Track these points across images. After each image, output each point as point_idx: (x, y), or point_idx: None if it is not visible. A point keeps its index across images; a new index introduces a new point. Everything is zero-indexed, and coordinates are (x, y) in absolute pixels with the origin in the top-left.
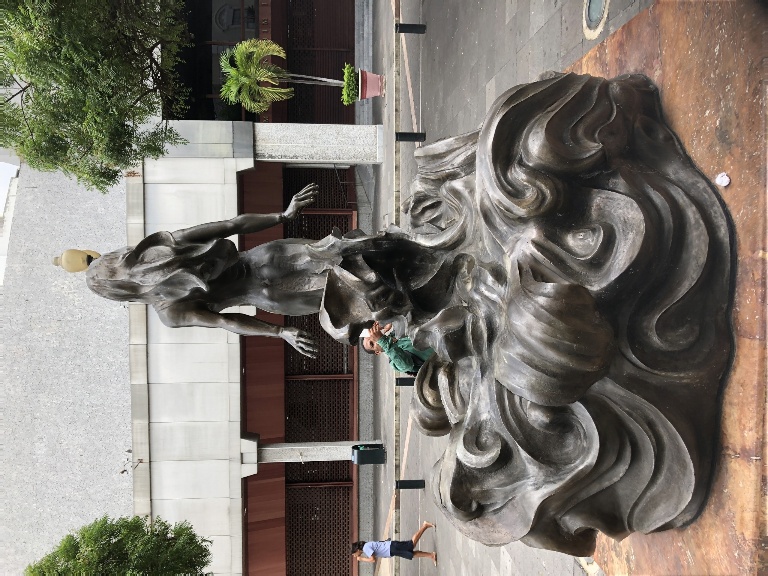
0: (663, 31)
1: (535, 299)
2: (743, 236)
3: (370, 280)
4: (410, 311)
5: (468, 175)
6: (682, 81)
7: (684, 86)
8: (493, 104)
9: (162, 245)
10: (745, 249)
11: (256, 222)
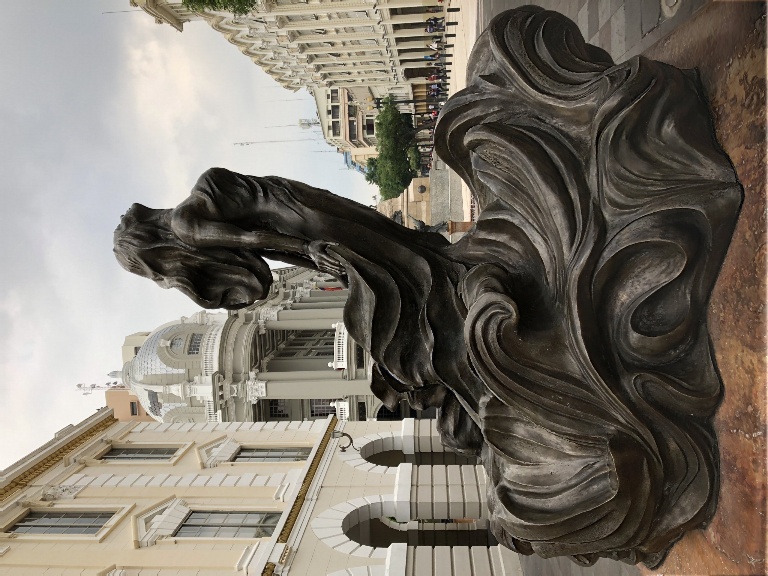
0: (732, 570)
1: (505, 543)
2: (649, 574)
3: (409, 389)
4: (441, 408)
5: (500, 450)
6: (702, 571)
7: (700, 571)
8: (520, 525)
9: (195, 300)
10: (646, 572)
11: (276, 249)
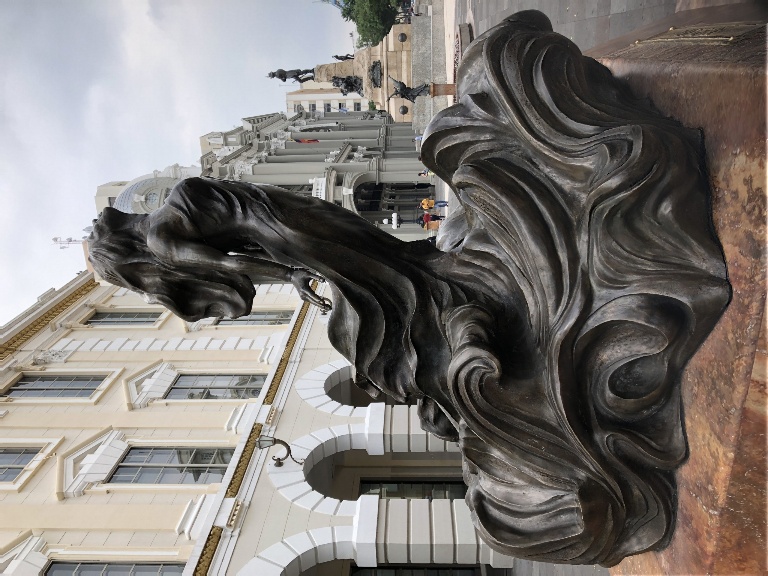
0: None
1: None
2: None
3: None
4: (422, 400)
5: (477, 466)
6: None
7: None
8: (493, 541)
9: (178, 314)
10: None
11: None
